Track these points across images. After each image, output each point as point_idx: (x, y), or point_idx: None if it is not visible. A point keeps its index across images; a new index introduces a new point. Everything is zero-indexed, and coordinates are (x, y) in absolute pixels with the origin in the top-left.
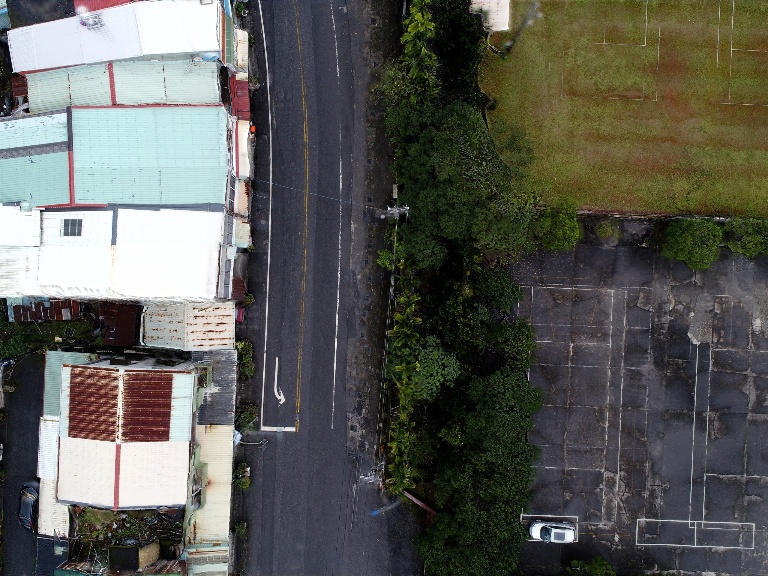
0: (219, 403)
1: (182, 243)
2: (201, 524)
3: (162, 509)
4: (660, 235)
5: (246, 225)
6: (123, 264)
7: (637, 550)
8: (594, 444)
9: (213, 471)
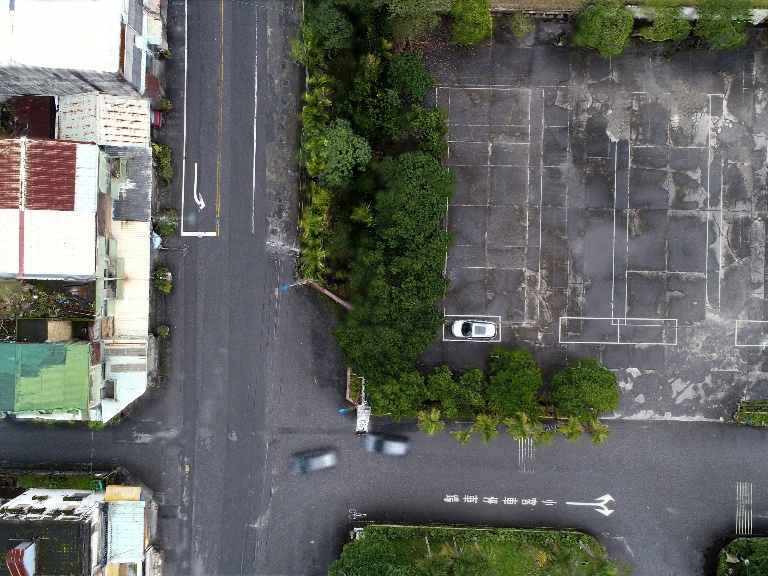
0: (135, 199)
1: (82, 13)
2: (119, 318)
3: (72, 286)
4: (575, 31)
5: (158, 22)
6: (23, 31)
7: (560, 348)
8: (515, 243)
9: (130, 267)
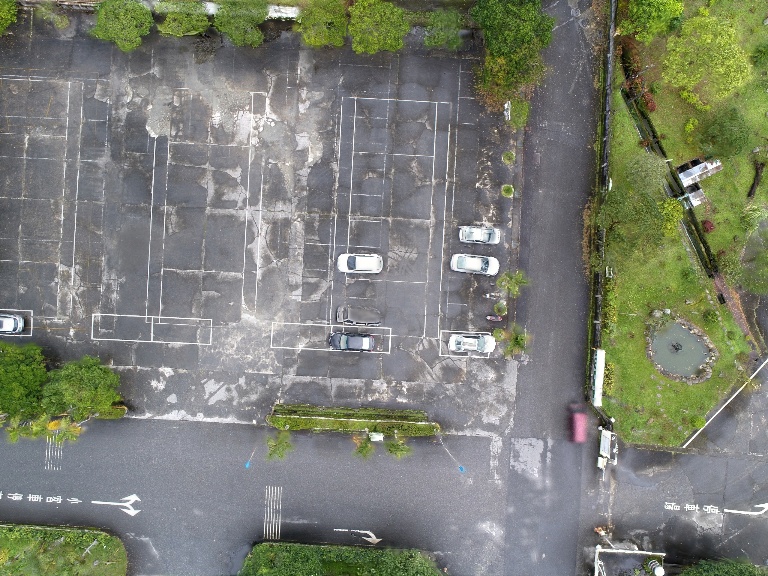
0: None
1: None
2: None
3: None
4: None
5: None
6: None
7: (92, 345)
8: (49, 237)
9: None
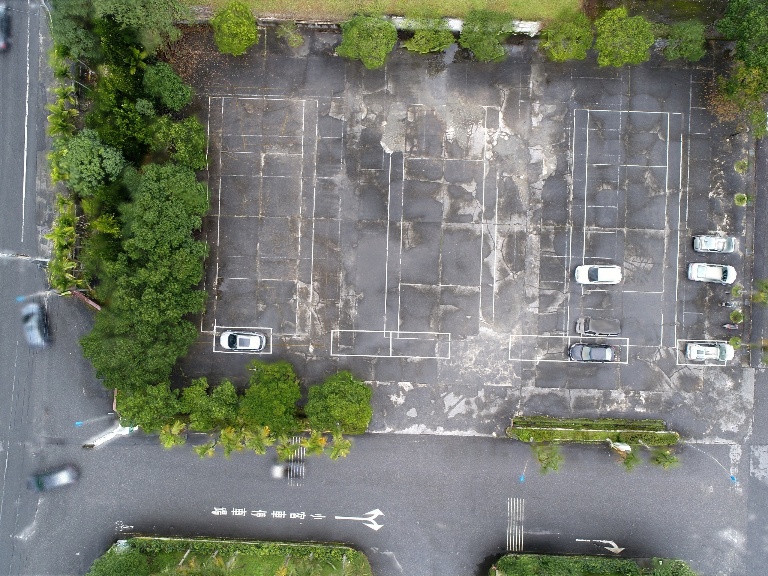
0: None
1: None
2: None
3: None
4: None
5: None
6: None
7: (332, 361)
8: (287, 255)
9: None
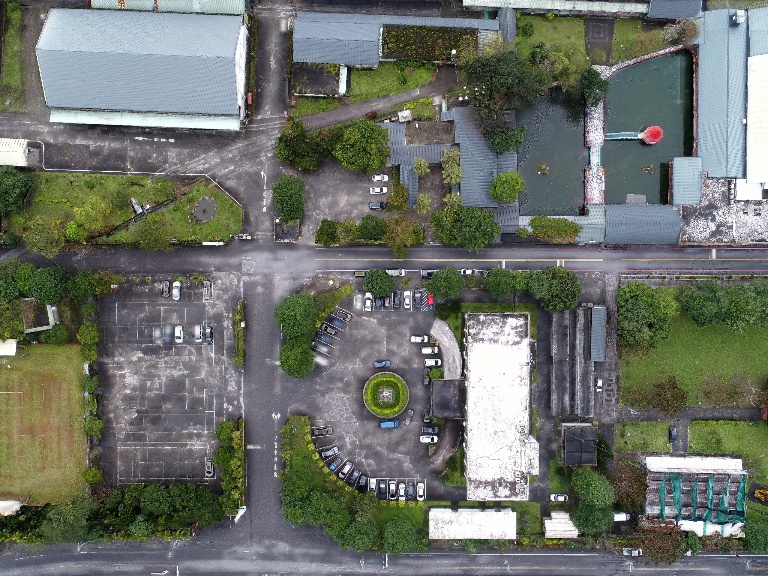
0: None
1: None
2: None
3: None
4: None
5: None
6: None
7: None
8: (177, 452)
9: None
